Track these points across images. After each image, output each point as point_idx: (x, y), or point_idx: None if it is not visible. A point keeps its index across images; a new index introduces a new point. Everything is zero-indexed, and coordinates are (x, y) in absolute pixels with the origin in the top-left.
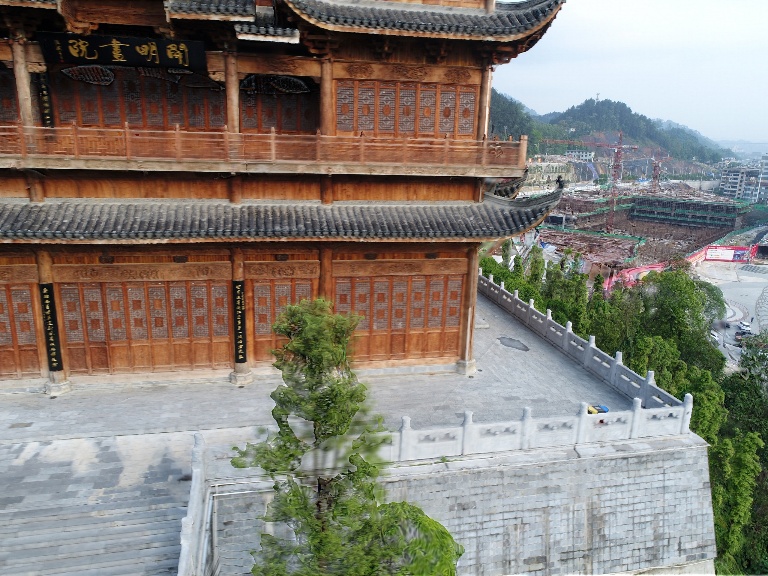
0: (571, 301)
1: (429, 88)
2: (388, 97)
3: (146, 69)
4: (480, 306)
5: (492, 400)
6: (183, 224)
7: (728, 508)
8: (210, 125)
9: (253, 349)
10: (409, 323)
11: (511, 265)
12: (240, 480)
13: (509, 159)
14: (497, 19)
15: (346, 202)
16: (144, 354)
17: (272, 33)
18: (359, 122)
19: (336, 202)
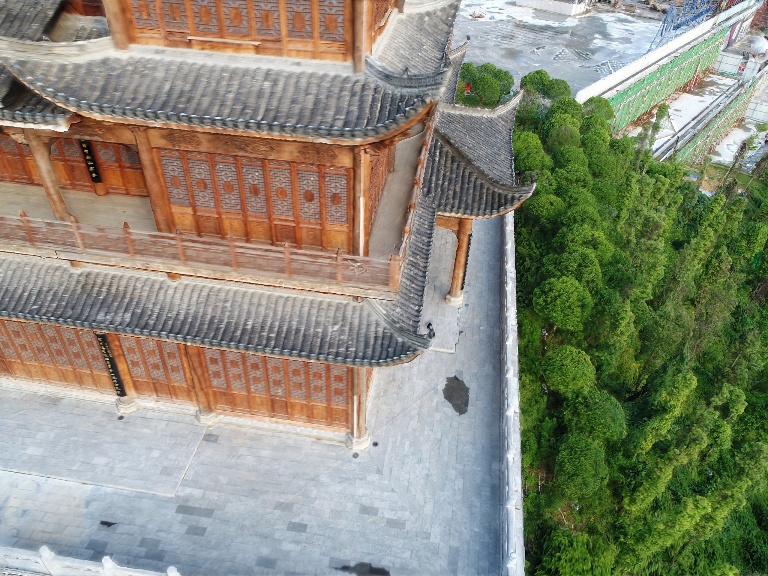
0: (705, 225)
1: (281, 165)
2: (227, 172)
3: None
4: (479, 301)
5: (345, 508)
6: (12, 295)
7: (746, 554)
8: (66, 155)
9: (133, 385)
10: (289, 393)
11: (700, 115)
12: (27, 574)
13: (376, 278)
14: (356, 93)
15: (196, 279)
16: (37, 370)
17: (30, 120)
18: (196, 198)
19: (184, 278)
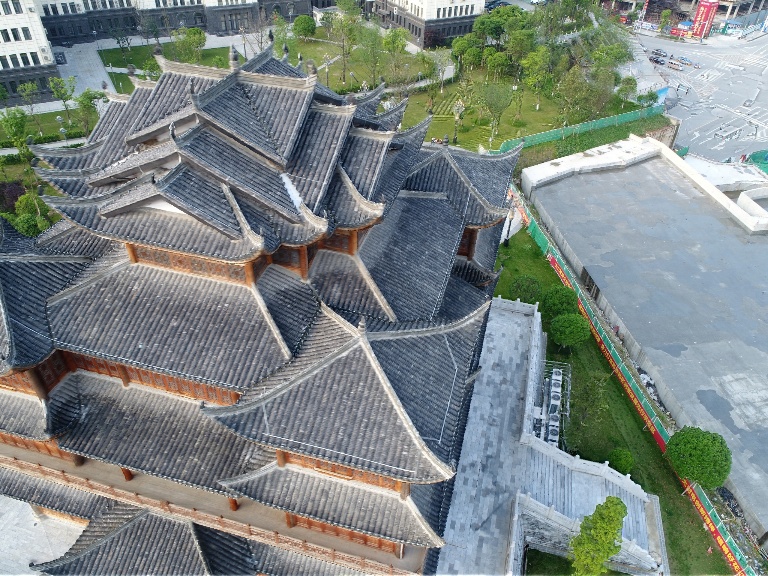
0: None
1: None
2: None
3: (467, 286)
4: None
5: (7, 506)
6: None
7: None
8: None
9: None
10: None
11: None
12: None
13: None
14: None
15: None
16: None
17: None
18: None
19: None
